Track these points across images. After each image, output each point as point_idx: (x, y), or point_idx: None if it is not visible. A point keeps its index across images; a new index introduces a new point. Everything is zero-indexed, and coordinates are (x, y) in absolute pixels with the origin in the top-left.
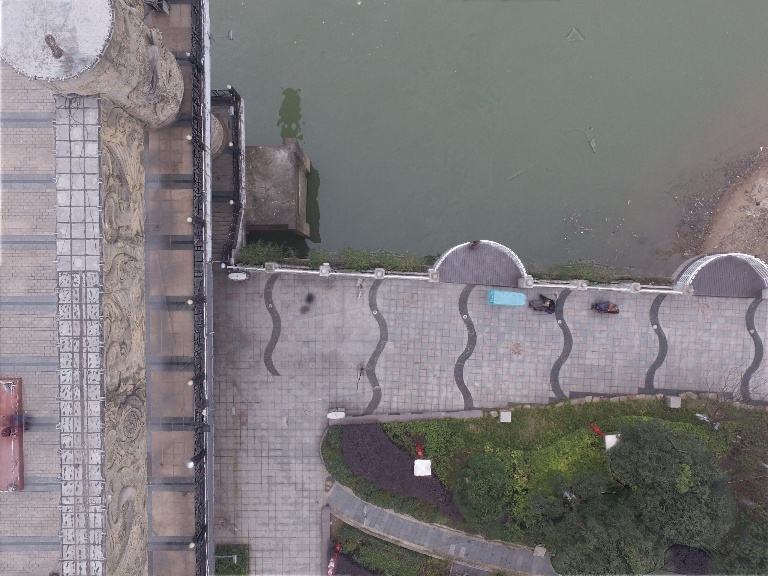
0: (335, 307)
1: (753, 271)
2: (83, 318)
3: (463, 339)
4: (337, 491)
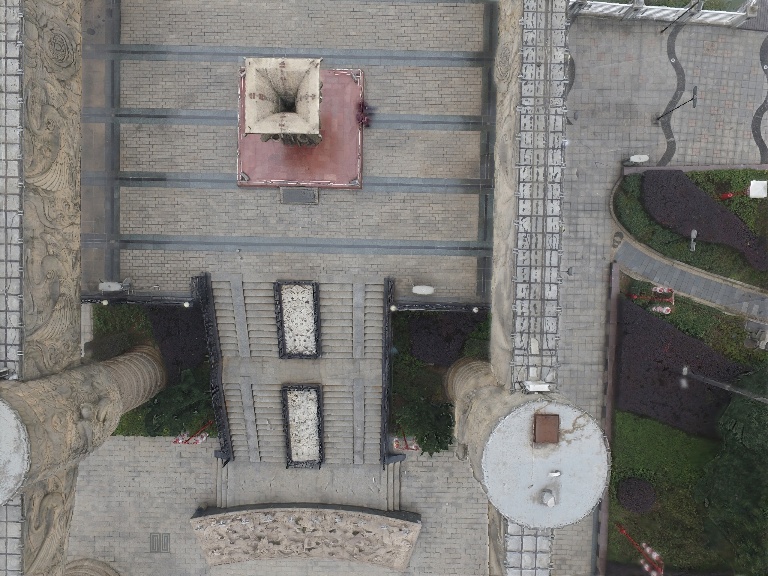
0: (632, 54)
1: None
2: None
3: (762, 90)
4: (625, 247)
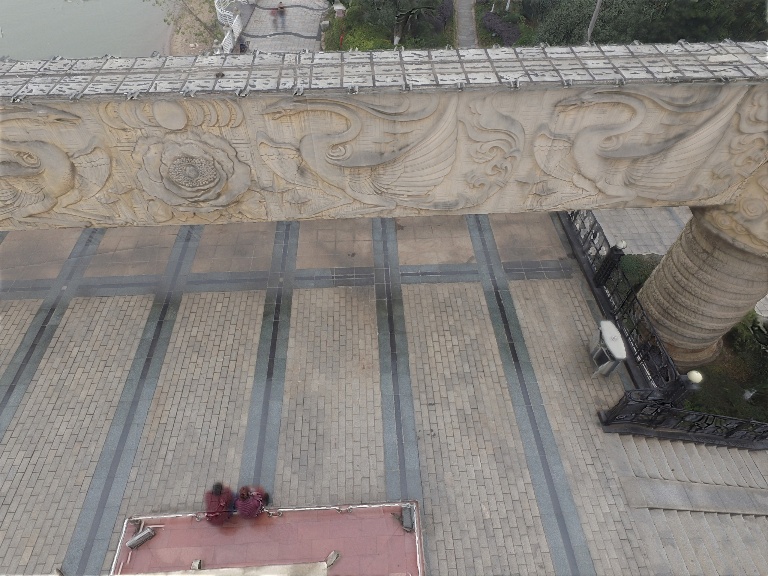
0: None
1: (234, 5)
2: None
3: None
4: None
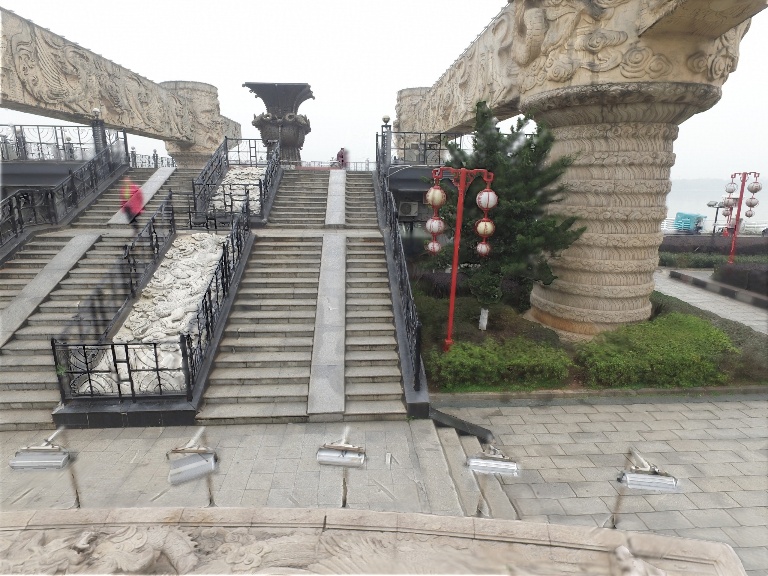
0: None
1: None
2: None
3: None
4: None
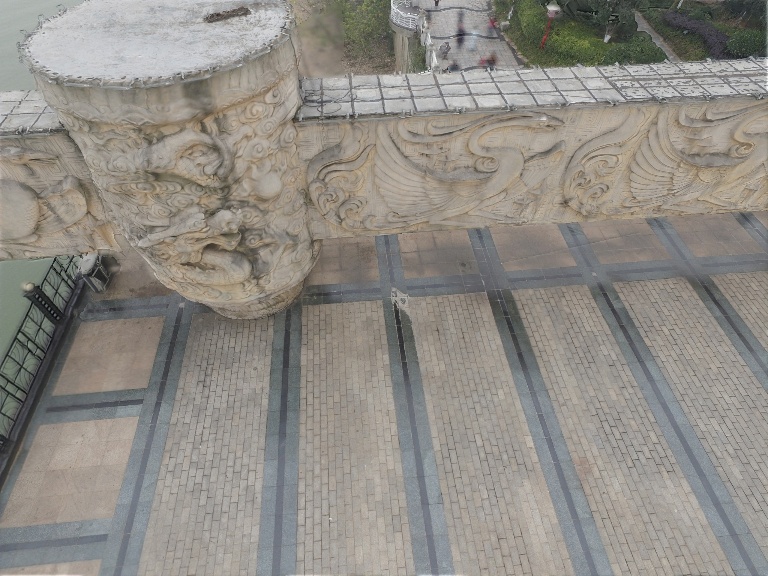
0: None
1: (401, 7)
2: (685, 76)
3: None
4: None
